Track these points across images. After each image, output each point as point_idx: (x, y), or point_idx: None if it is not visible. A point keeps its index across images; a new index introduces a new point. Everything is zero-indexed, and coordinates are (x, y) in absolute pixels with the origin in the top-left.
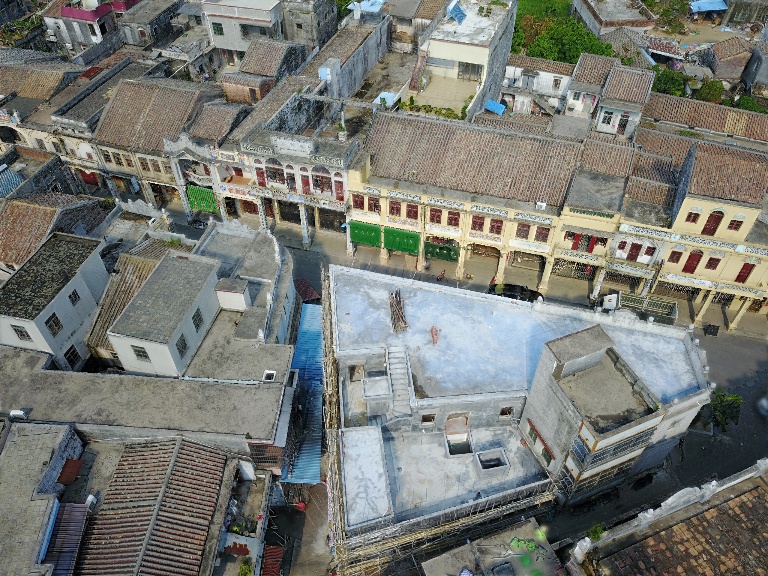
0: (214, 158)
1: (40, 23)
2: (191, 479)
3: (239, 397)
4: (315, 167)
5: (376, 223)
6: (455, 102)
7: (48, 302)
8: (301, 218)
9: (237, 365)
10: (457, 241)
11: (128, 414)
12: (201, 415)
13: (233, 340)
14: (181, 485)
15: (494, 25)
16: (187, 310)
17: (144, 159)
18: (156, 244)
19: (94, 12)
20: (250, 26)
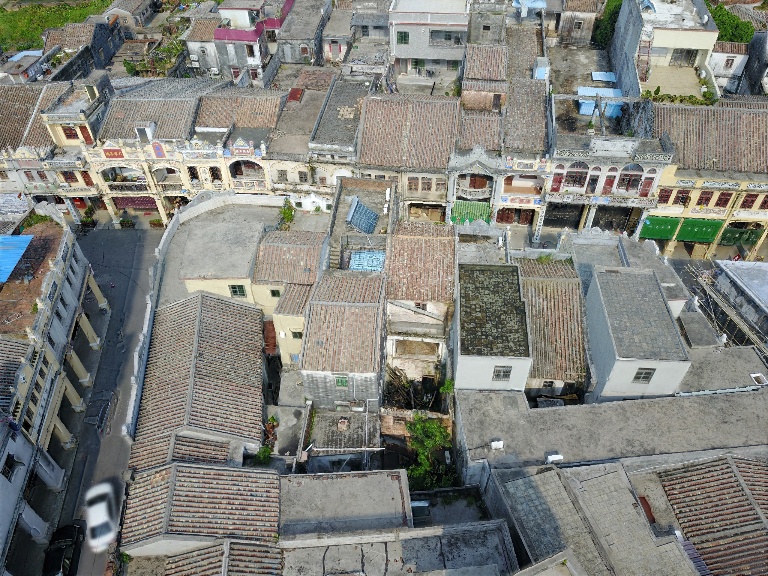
0: (508, 169)
1: (183, 49)
2: (767, 496)
3: (753, 405)
4: (626, 166)
5: (678, 216)
6: (687, 89)
7: (524, 336)
8: (588, 220)
9: (717, 373)
10: (762, 224)
11: (661, 440)
12: (733, 429)
13: (690, 349)
14: (765, 504)
15: (687, 10)
16: (673, 324)
17: (414, 178)
18: (525, 263)
19: (254, 31)
20: (435, 32)
